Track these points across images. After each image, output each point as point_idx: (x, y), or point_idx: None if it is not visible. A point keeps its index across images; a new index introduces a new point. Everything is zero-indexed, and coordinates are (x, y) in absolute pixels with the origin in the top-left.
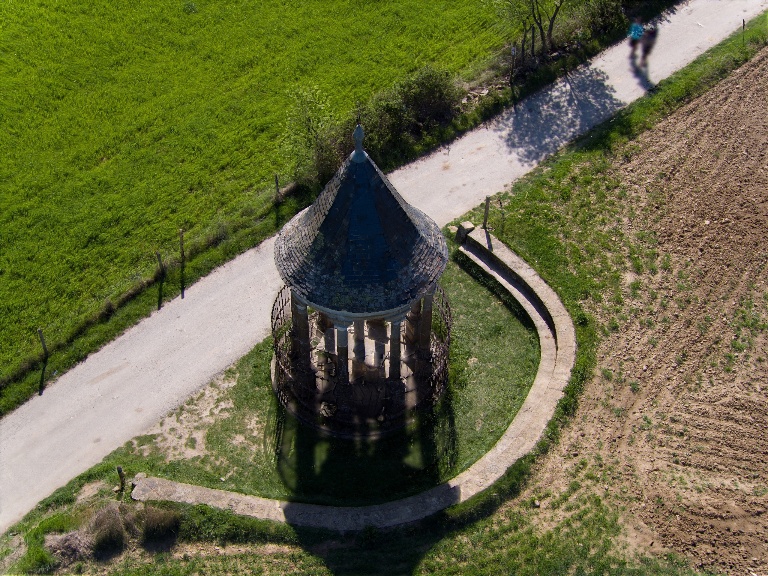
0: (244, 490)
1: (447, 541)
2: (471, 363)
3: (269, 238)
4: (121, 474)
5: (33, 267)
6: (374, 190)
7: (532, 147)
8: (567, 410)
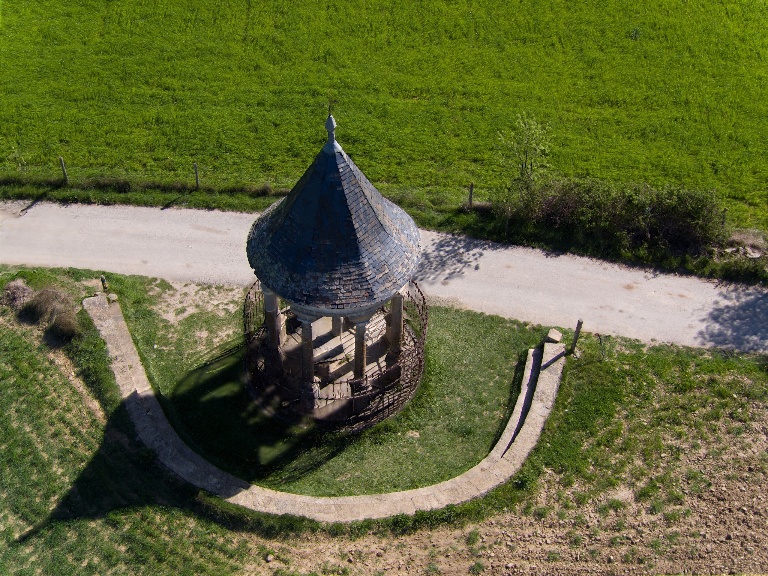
0: (146, 361)
1: (180, 512)
2: (410, 434)
3: (423, 229)
4: (104, 284)
5: (269, 131)
6: (327, 185)
7: (730, 331)
8: (395, 525)
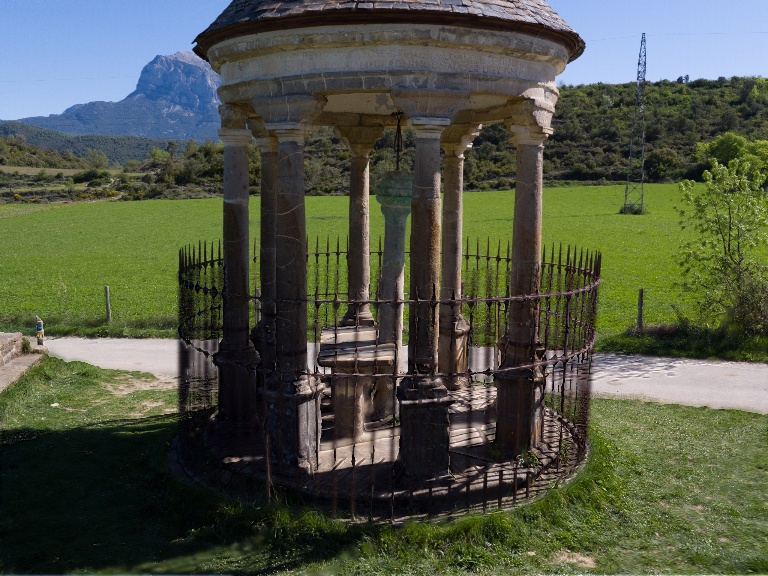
0: (5, 397)
1: None
2: (565, 558)
3: None
4: None
5: None
6: None
7: None
8: None
